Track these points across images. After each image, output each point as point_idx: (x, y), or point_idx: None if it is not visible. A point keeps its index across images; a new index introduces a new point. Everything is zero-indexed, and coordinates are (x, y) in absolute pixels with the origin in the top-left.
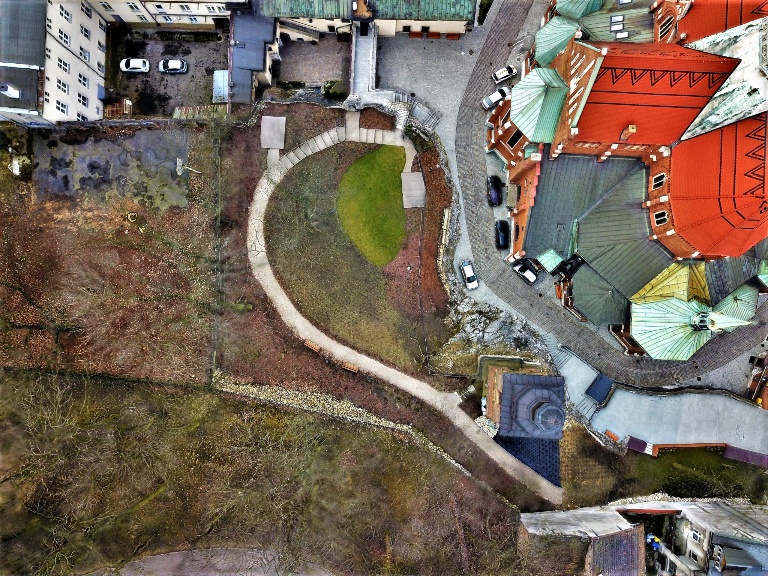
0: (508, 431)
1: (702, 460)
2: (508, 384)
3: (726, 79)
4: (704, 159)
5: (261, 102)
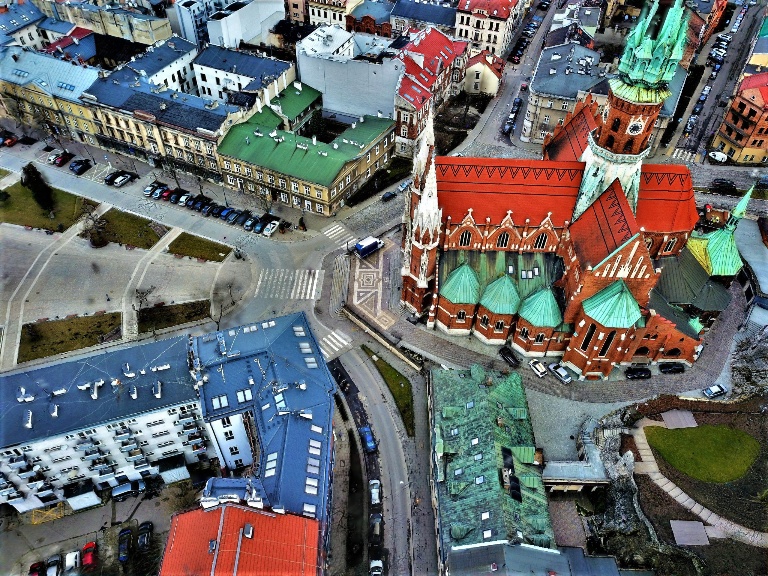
0: None
1: None
2: None
3: None
4: (652, 210)
5: (664, 545)
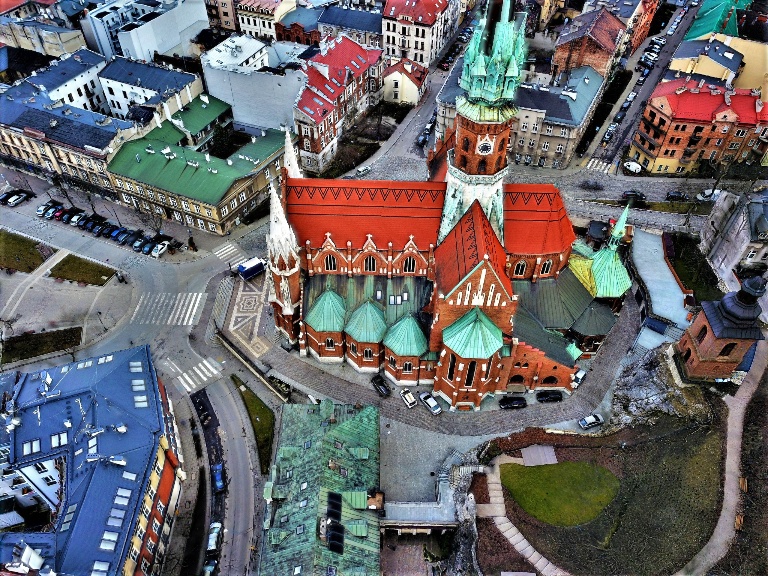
0: (760, 332)
1: (683, 268)
2: (724, 332)
3: (482, 210)
4: (521, 231)
5: None
